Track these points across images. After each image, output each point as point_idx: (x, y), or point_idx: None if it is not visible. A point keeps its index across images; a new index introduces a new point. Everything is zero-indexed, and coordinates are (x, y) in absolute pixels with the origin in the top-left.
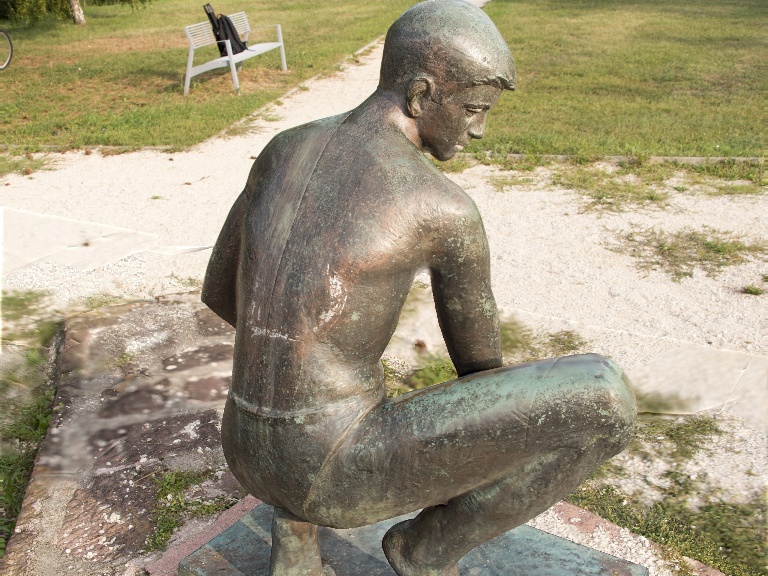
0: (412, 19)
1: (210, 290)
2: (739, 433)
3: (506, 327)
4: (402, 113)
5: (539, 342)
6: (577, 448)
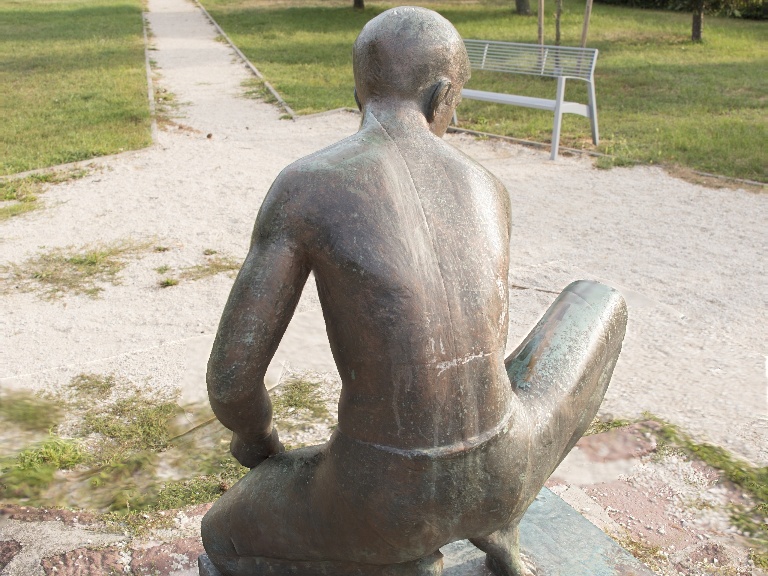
0: (422, 28)
1: (248, 381)
2: (328, 379)
3: (16, 399)
4: (426, 120)
5: (70, 396)
6: (619, 348)
